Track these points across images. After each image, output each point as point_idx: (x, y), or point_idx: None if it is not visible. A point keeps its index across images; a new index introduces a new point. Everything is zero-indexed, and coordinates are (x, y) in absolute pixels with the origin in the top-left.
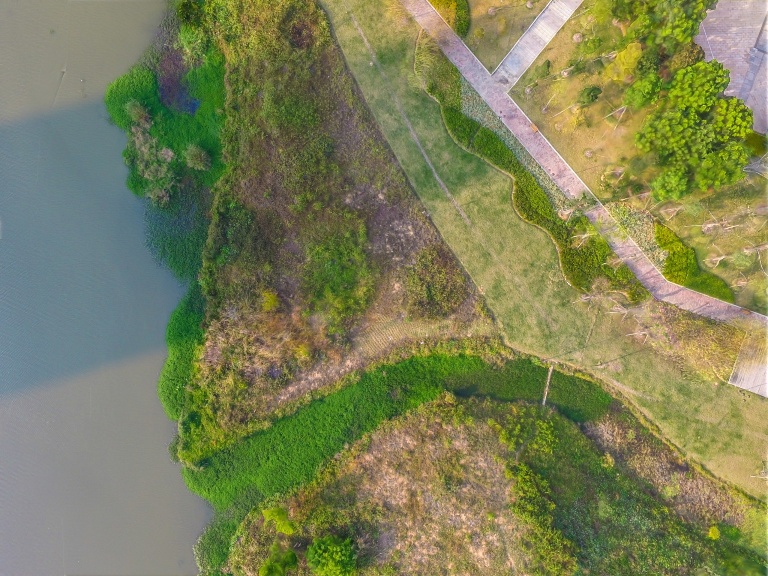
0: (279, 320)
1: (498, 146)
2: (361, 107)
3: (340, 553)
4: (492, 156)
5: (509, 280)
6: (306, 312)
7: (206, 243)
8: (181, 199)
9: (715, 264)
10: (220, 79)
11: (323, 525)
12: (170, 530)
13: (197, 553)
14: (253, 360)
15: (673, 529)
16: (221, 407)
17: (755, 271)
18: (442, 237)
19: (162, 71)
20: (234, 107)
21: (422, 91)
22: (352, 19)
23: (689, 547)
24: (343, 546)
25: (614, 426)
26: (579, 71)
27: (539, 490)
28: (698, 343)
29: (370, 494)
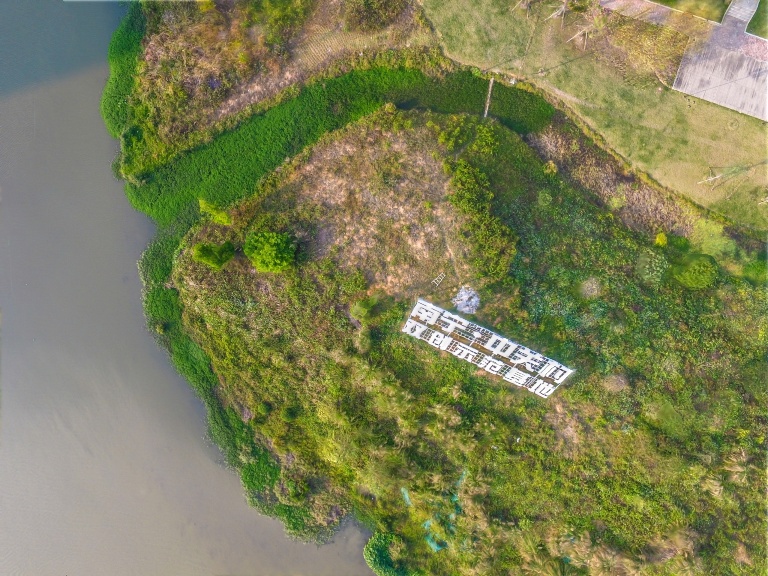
0: (218, 32)
1: None
2: None
3: (276, 237)
4: None
5: None
6: (244, 22)
7: None
8: None
9: None
10: None
11: (263, 228)
12: (114, 246)
13: (141, 268)
14: (192, 71)
15: (618, 234)
16: (162, 121)
17: None
18: None
19: None
20: None
21: None
22: None
23: (635, 250)
24: None
25: (557, 137)
26: None
27: (478, 183)
28: (640, 48)
29: (310, 197)
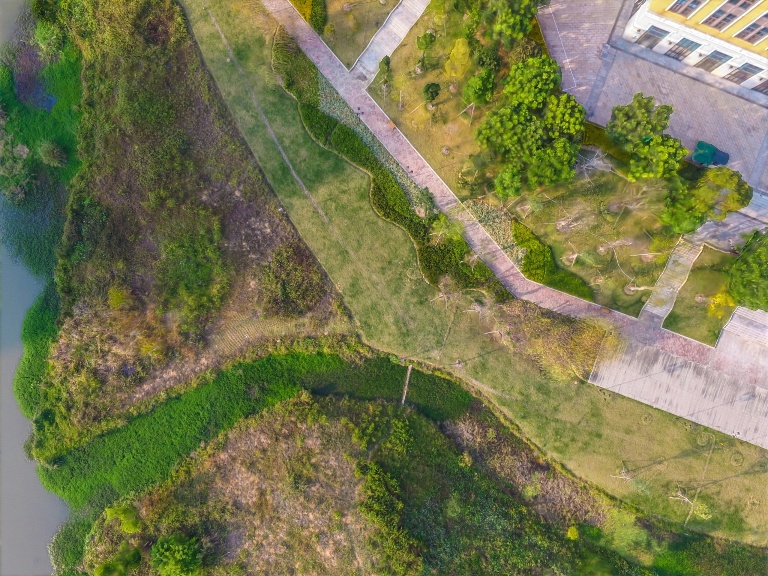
0: (133, 318)
1: (355, 143)
2: (217, 104)
3: (181, 552)
4: (349, 153)
5: (367, 278)
6: (159, 310)
7: (61, 240)
8: (37, 196)
9: (572, 262)
10: (77, 75)
11: (174, 524)
12: (25, 528)
13: (52, 551)
14: (106, 358)
15: (530, 529)
16: (75, 405)
17: (612, 269)
18: (299, 234)
19: (19, 67)
20: (89, 103)
21: (279, 87)
22: (209, 15)
23: (546, 547)
24: (186, 545)
25: (474, 425)
26: (433, 67)
27: (388, 489)
28: (557, 342)
29: (221, 493)
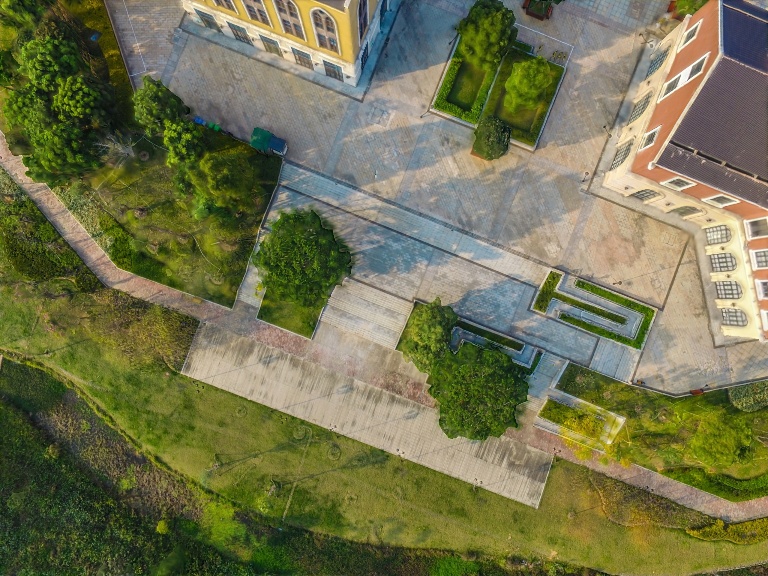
0: None
1: None
2: None
3: None
4: None
5: None
6: None
7: None
8: None
9: (155, 251)
10: None
11: None
12: None
13: None
14: None
15: (116, 522)
16: None
17: (198, 258)
18: None
19: None
20: None
21: None
22: None
23: (128, 541)
24: None
25: (68, 416)
26: None
27: None
28: (149, 332)
29: None
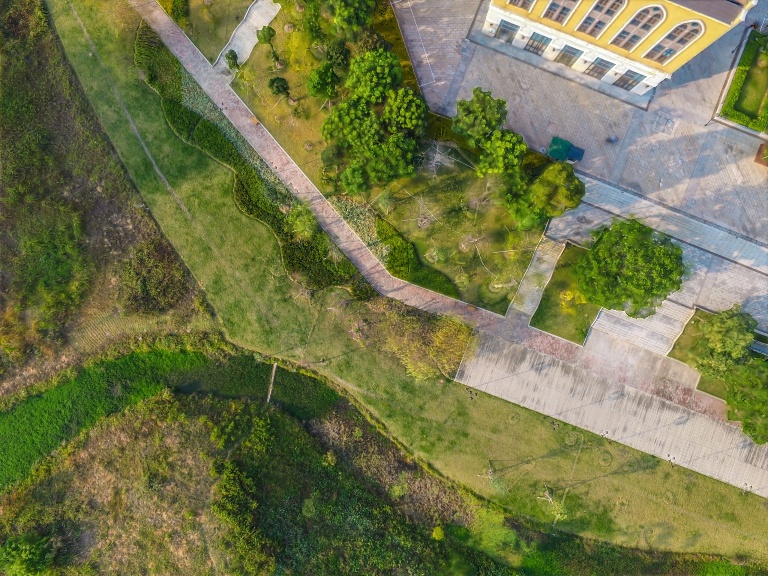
0: None
1: (218, 138)
2: (79, 98)
3: (28, 551)
4: (212, 149)
5: (230, 275)
6: (17, 306)
7: None
8: None
9: (435, 259)
10: None
11: (29, 523)
12: None
13: None
14: None
15: (394, 529)
16: None
17: (476, 266)
18: (162, 231)
19: None
20: None
21: (142, 82)
22: (72, 9)
23: (409, 547)
24: (35, 544)
25: (340, 424)
26: None
27: (243, 488)
28: (423, 340)
29: (78, 492)
